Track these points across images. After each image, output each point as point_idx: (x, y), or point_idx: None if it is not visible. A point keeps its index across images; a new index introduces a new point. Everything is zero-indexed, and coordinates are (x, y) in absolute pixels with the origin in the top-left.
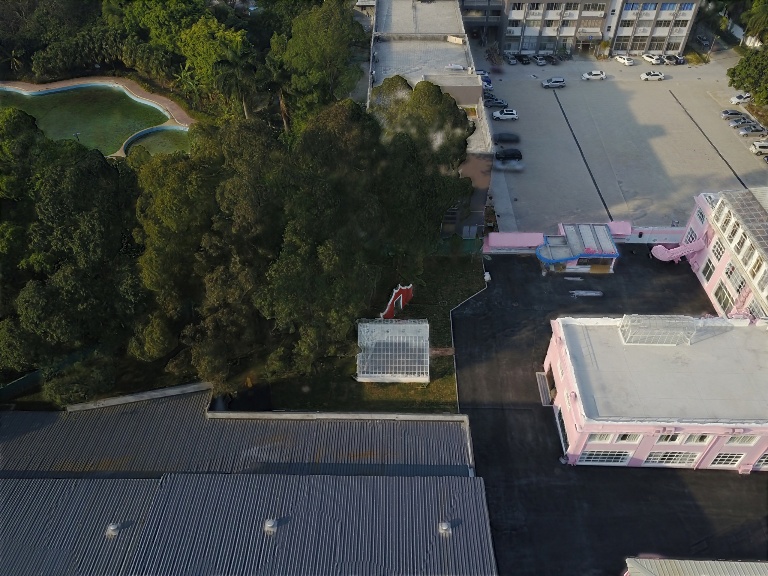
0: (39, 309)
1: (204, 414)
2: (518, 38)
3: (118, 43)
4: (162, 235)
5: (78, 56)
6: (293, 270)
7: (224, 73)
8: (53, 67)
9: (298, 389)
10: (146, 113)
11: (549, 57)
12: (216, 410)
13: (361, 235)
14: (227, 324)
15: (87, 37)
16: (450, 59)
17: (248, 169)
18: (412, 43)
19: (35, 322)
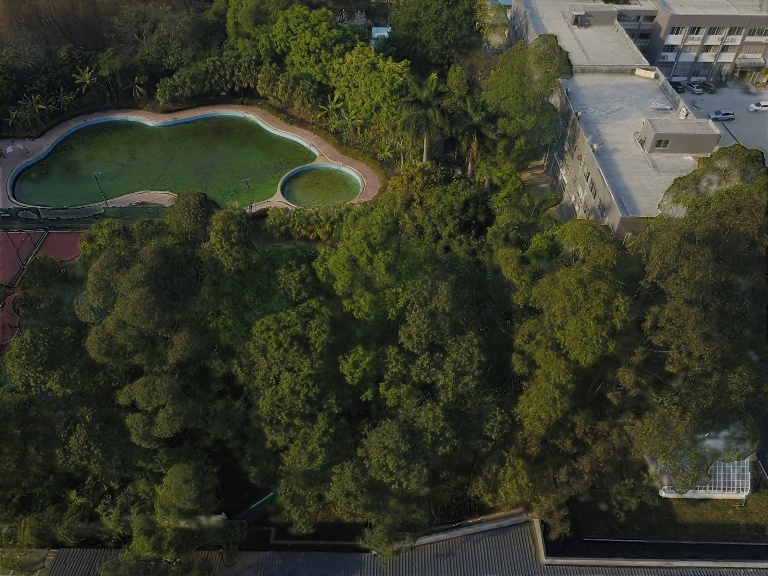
0: (401, 457)
1: (537, 558)
2: (671, 64)
3: (252, 70)
4: (569, 370)
5: (207, 83)
6: (704, 405)
7: (412, 113)
8: (180, 95)
9: (595, 507)
10: (289, 148)
11: (706, 85)
12: (556, 556)
13: (763, 355)
14: (603, 465)
15: (218, 63)
16: (648, 96)
17: (687, 291)
18: (596, 76)
19: (390, 470)
